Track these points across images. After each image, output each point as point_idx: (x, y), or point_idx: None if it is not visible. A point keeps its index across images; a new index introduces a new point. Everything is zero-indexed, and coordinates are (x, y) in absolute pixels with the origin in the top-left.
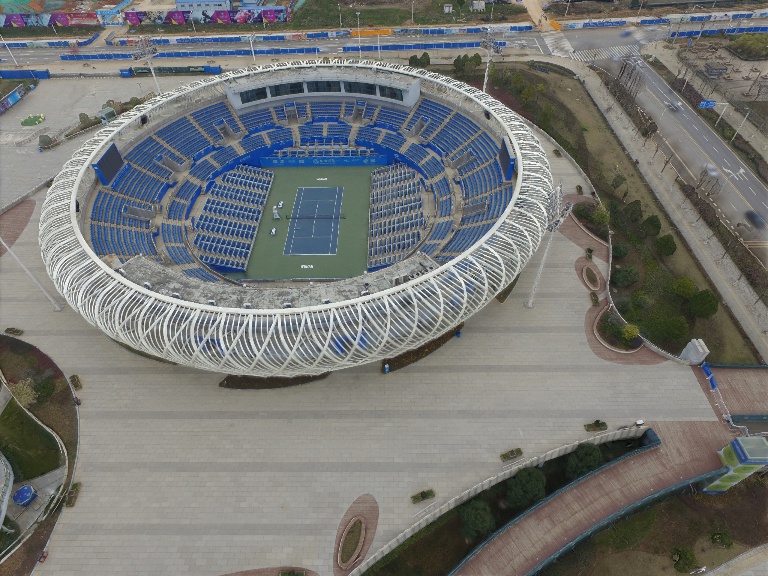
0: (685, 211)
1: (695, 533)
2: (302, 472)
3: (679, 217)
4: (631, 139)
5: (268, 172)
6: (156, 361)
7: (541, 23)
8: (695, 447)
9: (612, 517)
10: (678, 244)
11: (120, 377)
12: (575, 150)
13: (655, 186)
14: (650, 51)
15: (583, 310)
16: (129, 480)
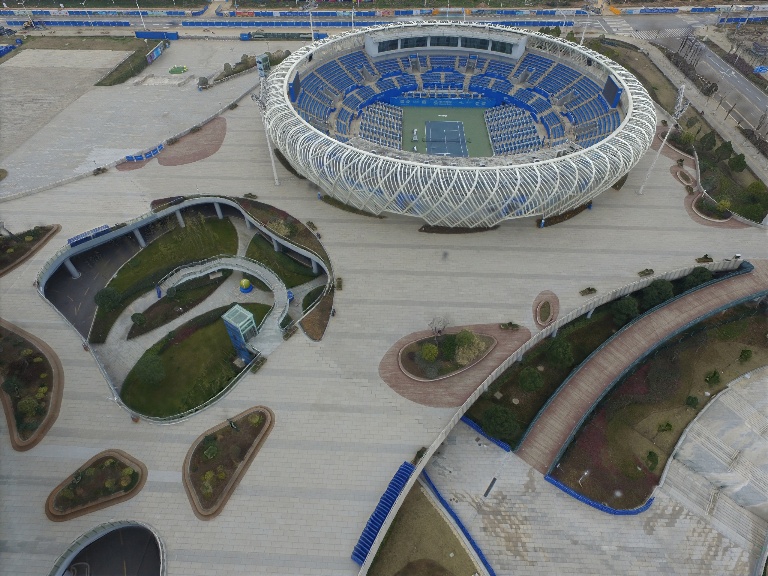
0: (747, 148)
1: None
2: (497, 278)
3: (742, 152)
4: (695, 97)
5: (398, 109)
6: (366, 216)
7: (603, 8)
8: None
9: (723, 308)
10: None
11: (343, 224)
12: None
13: (720, 130)
14: (702, 33)
15: (682, 197)
16: (375, 278)
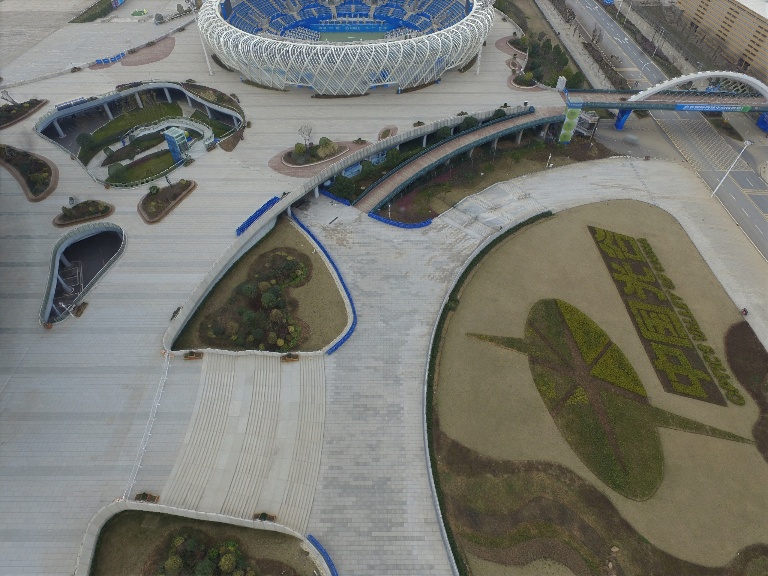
0: (583, 55)
1: (552, 155)
2: (359, 120)
3: (579, 58)
4: (558, 24)
5: (316, 33)
6: (274, 91)
7: None
8: (552, 113)
9: (508, 132)
10: (574, 68)
11: (257, 95)
12: (519, 26)
13: (568, 45)
14: None
15: (507, 76)
16: (274, 122)
